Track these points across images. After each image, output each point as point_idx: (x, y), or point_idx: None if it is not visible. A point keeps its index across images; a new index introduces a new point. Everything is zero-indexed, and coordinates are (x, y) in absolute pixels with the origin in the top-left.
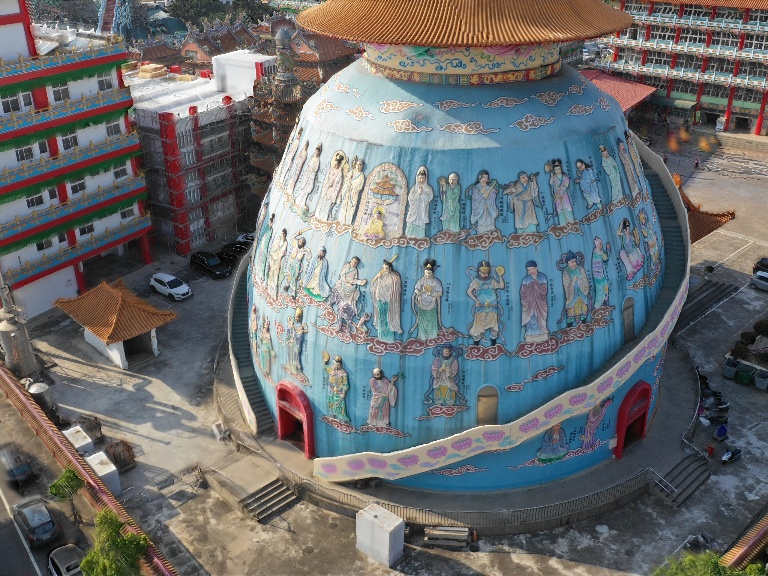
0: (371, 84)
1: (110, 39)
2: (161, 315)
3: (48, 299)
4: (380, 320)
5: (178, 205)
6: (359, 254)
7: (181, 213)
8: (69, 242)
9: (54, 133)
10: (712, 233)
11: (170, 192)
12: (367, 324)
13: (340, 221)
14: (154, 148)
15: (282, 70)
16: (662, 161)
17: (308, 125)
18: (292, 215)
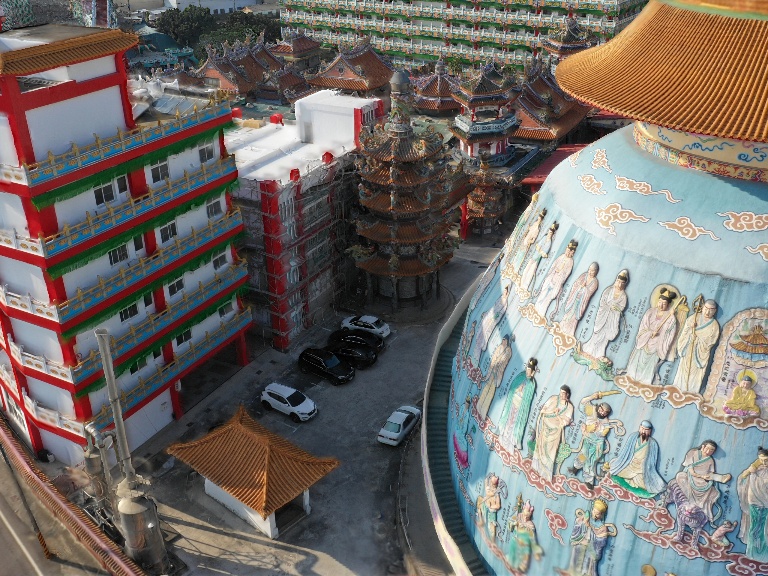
0: (691, 184)
1: (214, 97)
2: (318, 464)
3: (141, 431)
4: (752, 532)
5: (280, 291)
6: (715, 437)
7: (282, 300)
8: (165, 356)
9: (153, 224)
10: None
11: (271, 277)
12: (728, 536)
13: (677, 387)
14: (247, 222)
15: (398, 120)
16: None
17: (591, 240)
18: (578, 368)
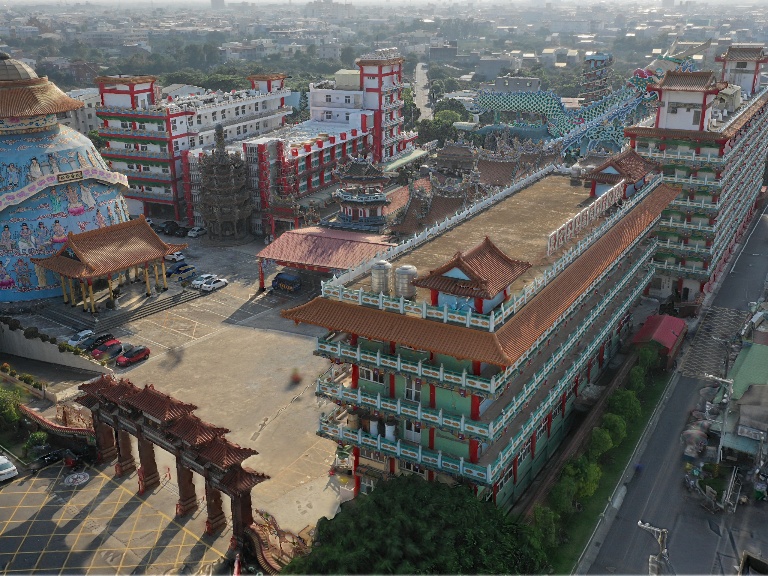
0: None
1: None
2: None
3: (132, 210)
4: None
5: None
6: None
7: (188, 203)
8: None
9: None
10: (193, 337)
11: None
12: None
13: None
14: None
15: None
16: (3, 195)
17: None
18: None
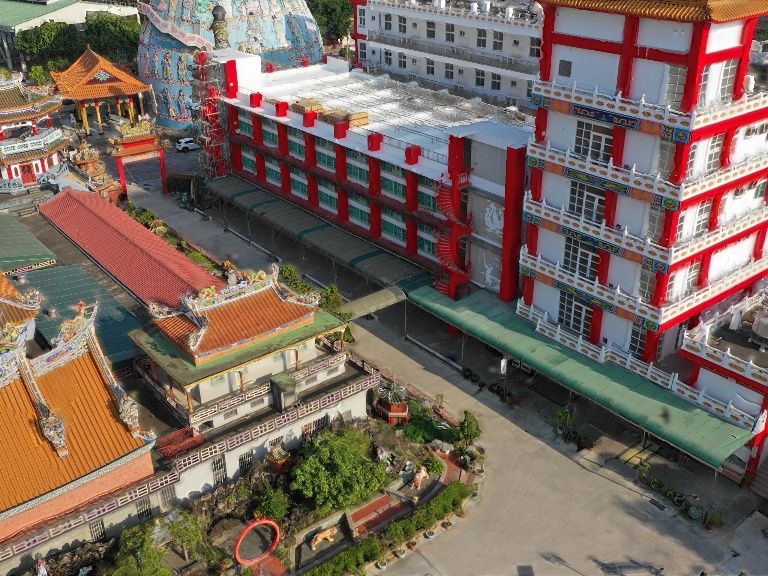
0: None
1: None
2: None
3: None
4: None
5: None
6: None
7: None
8: None
9: None
10: None
11: None
12: None
13: None
14: None
15: None
16: None
17: None
18: None
